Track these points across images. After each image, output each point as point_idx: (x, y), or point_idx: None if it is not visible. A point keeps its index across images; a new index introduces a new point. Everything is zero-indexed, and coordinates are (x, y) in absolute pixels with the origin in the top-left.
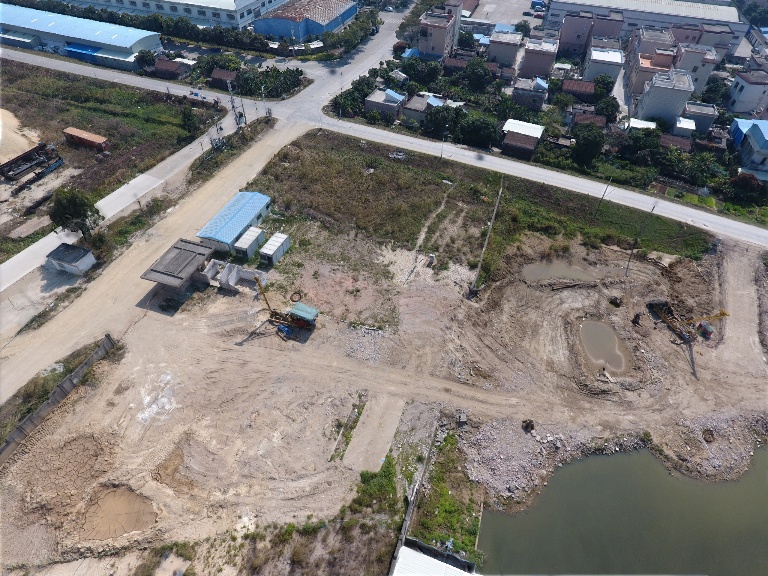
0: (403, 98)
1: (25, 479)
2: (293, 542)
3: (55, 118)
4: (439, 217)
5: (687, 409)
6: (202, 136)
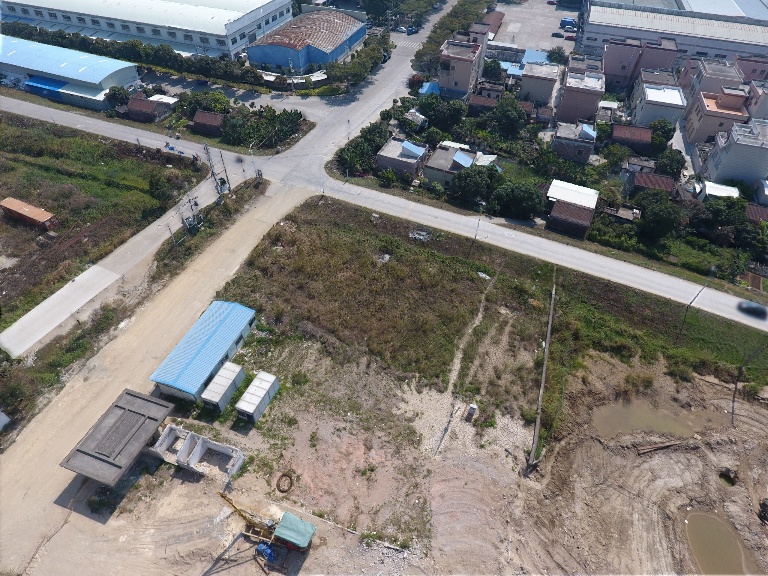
0: (423, 152)
1: None
2: None
3: None
4: (477, 335)
5: None
6: (175, 206)
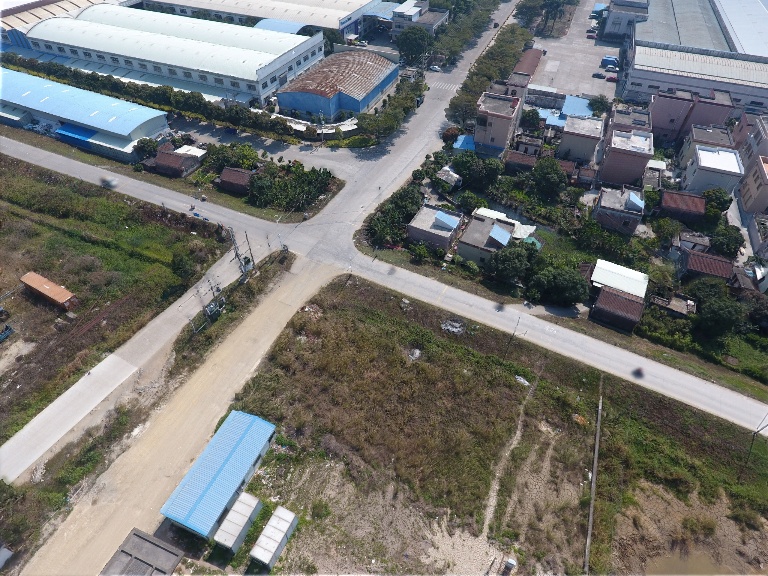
0: (457, 223)
1: None
2: None
3: (20, 247)
4: (516, 461)
5: None
6: (197, 283)
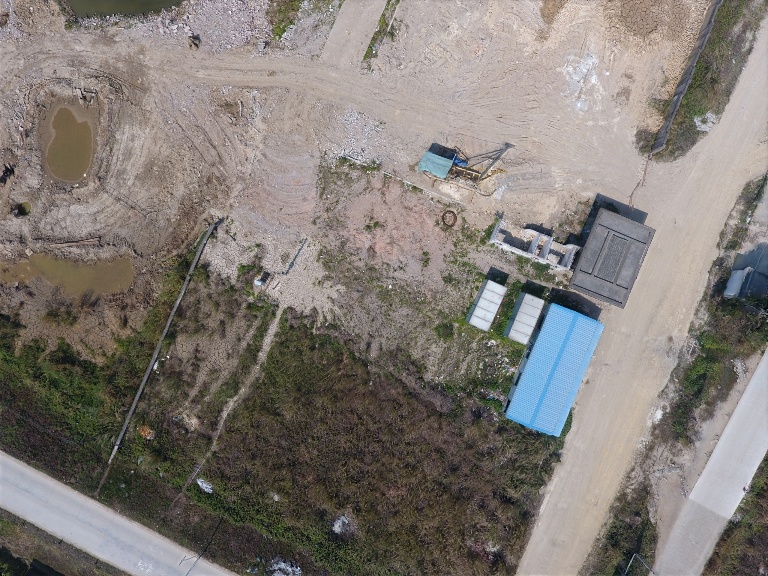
0: None
1: (678, 2)
2: None
3: None
4: (234, 382)
5: (8, 51)
6: None
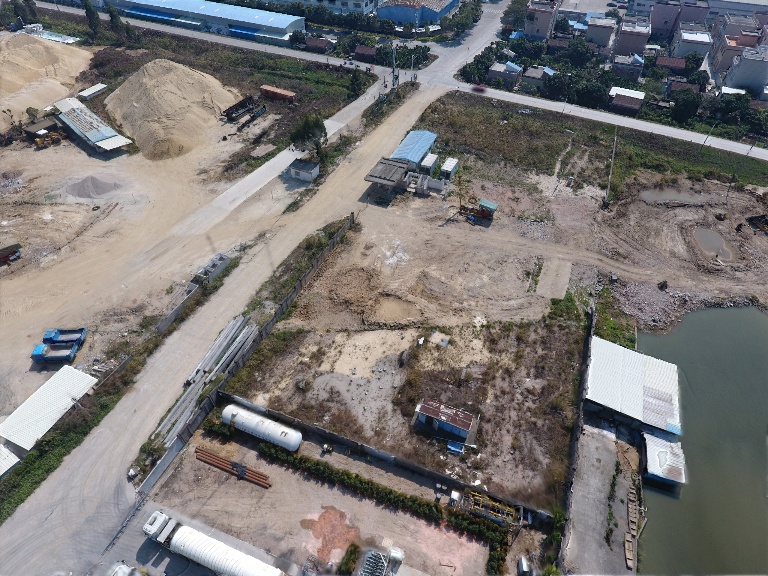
0: (521, 69)
1: (326, 289)
2: (515, 331)
3: (245, 80)
4: (569, 154)
5: None
6: (364, 94)
